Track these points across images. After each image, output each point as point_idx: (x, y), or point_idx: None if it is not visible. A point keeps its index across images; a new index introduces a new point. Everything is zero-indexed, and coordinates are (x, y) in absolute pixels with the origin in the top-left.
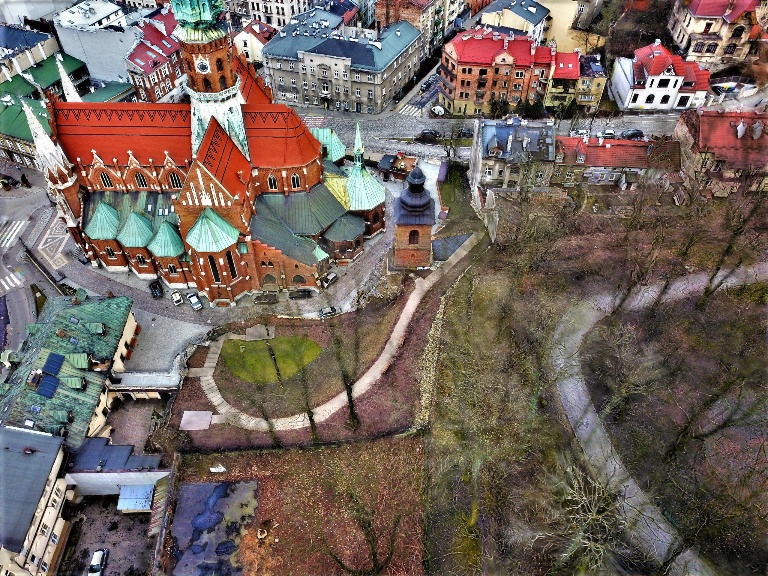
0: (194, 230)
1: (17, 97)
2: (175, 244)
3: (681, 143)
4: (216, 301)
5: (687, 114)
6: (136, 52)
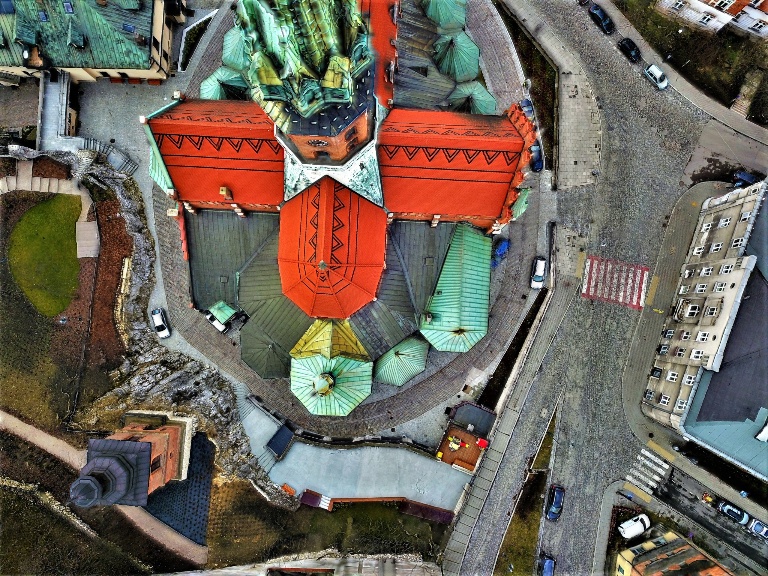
0: None
1: None
2: None
3: None
4: None
5: None
6: None
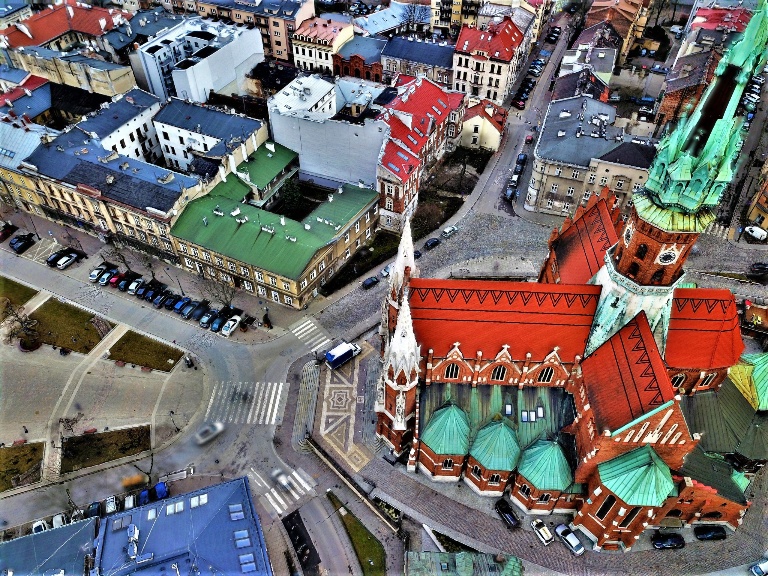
0: (625, 475)
1: (260, 216)
2: (562, 472)
3: None
4: (603, 543)
5: None
6: (387, 154)
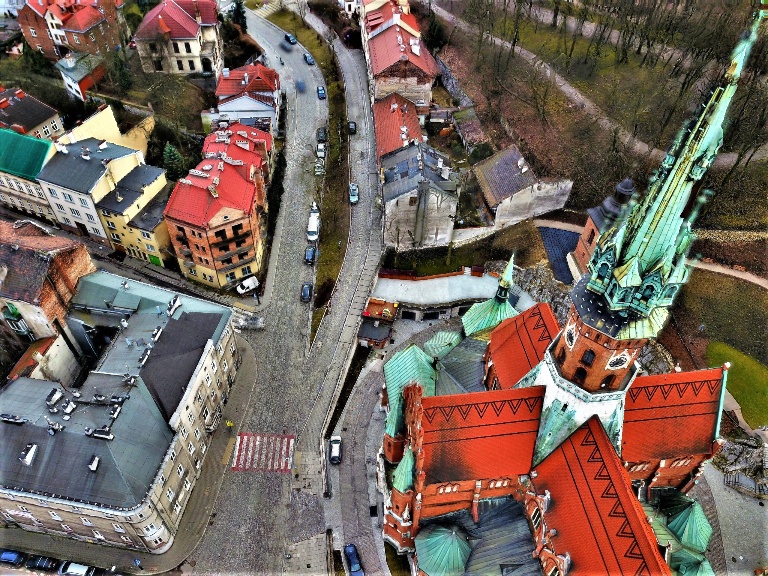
0: None
1: None
2: None
3: (398, 91)
4: None
5: (388, 71)
6: None
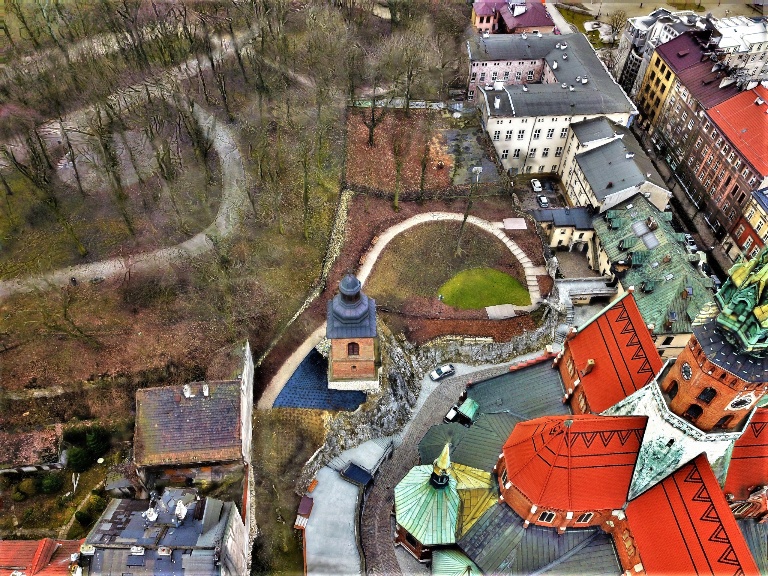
0: None
1: None
2: None
3: None
4: None
5: None
6: None
